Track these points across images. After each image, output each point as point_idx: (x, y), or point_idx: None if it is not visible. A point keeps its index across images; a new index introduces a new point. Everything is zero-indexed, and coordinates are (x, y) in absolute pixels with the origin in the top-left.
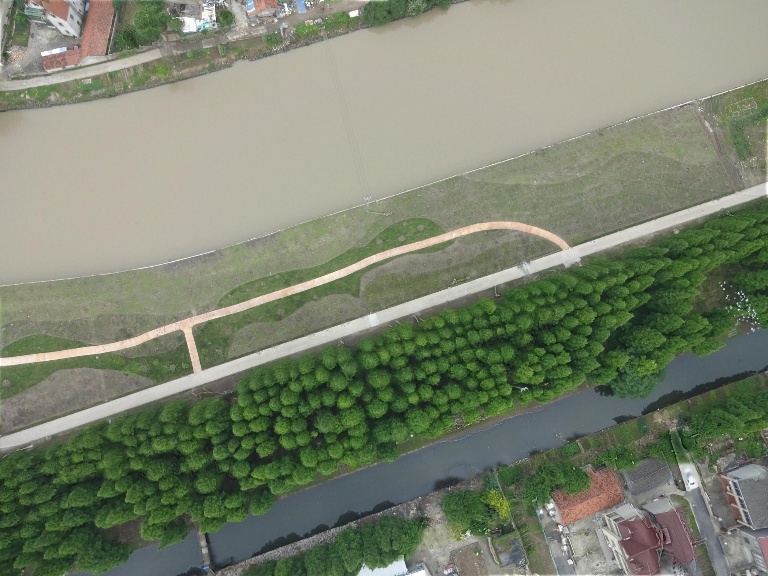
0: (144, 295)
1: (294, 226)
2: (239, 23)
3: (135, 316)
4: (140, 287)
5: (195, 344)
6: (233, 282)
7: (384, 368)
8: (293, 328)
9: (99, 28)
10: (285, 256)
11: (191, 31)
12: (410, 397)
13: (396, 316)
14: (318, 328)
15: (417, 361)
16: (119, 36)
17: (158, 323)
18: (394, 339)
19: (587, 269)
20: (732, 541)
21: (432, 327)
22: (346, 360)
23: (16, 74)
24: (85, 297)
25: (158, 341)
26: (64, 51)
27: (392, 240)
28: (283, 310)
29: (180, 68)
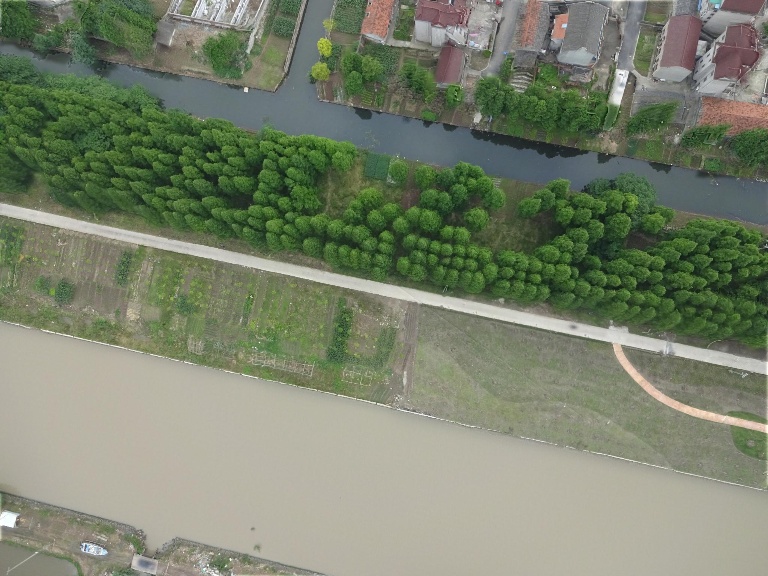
0: None
1: None
2: None
3: None
4: None
5: None
6: None
7: None
8: None
9: None
10: None
11: None
12: None
13: None
14: None
15: None
16: None
17: None
18: None
19: None
20: (615, 8)
21: None
22: None
23: None
24: None
25: None
26: None
27: None
28: None
29: None
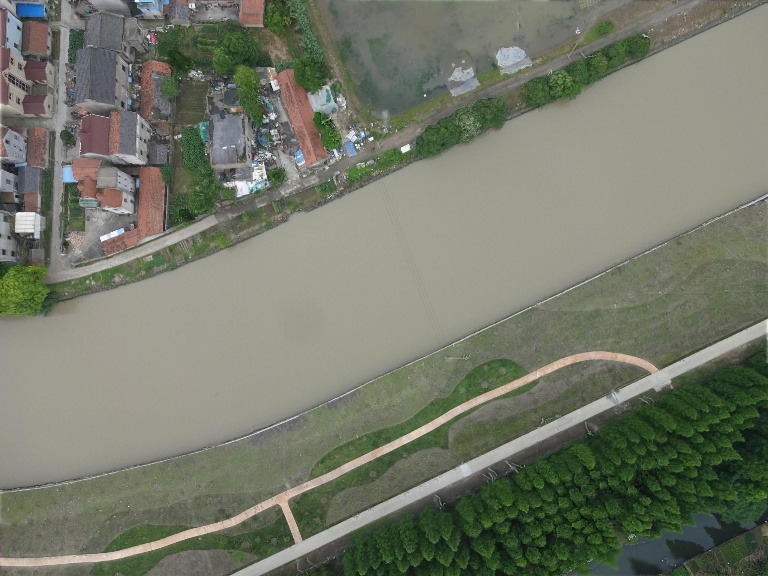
0: (236, 472)
1: (373, 381)
2: (290, 176)
3: (231, 496)
4: (231, 464)
5: (293, 516)
6: (321, 449)
7: (488, 534)
8: (386, 488)
9: (153, 206)
10: (369, 415)
11: (244, 194)
12: (518, 563)
13: (488, 463)
14: (411, 485)
15: (520, 523)
16: (173, 207)
17: (254, 501)
18: (496, 509)
19: (684, 406)
20: None
21: (532, 488)
22: (449, 531)
23: (79, 262)
24: (179, 480)
25: (257, 518)
26: (122, 233)
27: (475, 387)
28: (375, 472)
29: (237, 231)
